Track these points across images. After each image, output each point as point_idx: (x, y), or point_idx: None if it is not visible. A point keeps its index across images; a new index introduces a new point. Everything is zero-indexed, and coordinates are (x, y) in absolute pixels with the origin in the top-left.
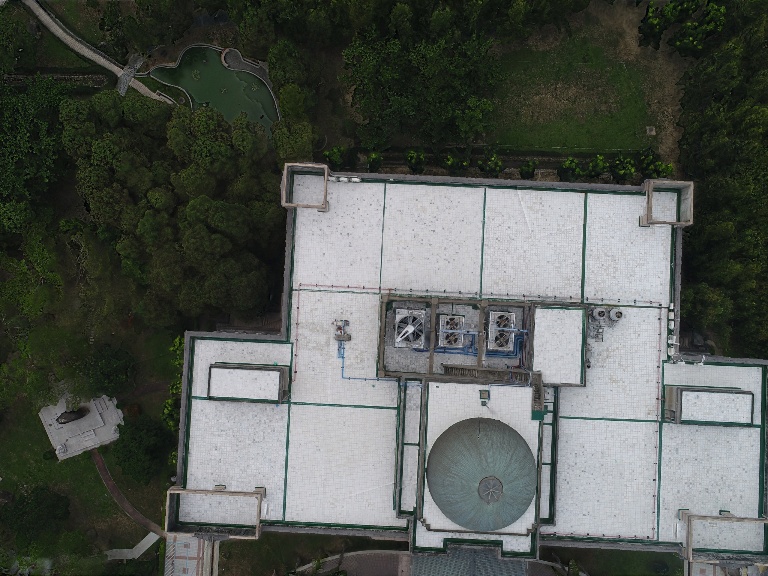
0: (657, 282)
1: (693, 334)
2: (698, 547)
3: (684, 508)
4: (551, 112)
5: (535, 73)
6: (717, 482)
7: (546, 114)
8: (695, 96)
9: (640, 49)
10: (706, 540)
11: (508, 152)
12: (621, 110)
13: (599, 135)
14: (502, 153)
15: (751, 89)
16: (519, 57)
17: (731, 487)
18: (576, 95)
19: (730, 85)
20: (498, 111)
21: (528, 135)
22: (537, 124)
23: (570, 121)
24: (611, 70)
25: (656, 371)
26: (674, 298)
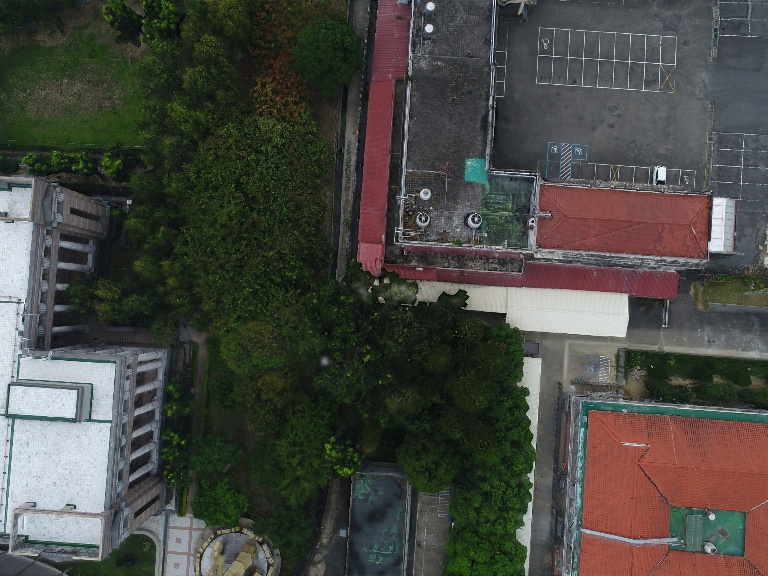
0: (18, 277)
1: (179, 330)
2: (43, 540)
3: (31, 501)
4: (56, 107)
5: (41, 68)
6: (65, 476)
7: (51, 109)
8: (159, 93)
9: (145, 46)
10: (52, 533)
11: (9, 147)
12: (125, 106)
13: (102, 131)
14: (4, 148)
15: (182, 87)
16: (26, 52)
17: (79, 481)
18: (81, 91)
19: (155, 83)
20: (4, 106)
21: (33, 130)
22: (42, 119)
23: (74, 117)
24: (116, 66)
25: (11, 365)
26: (27, 293)
